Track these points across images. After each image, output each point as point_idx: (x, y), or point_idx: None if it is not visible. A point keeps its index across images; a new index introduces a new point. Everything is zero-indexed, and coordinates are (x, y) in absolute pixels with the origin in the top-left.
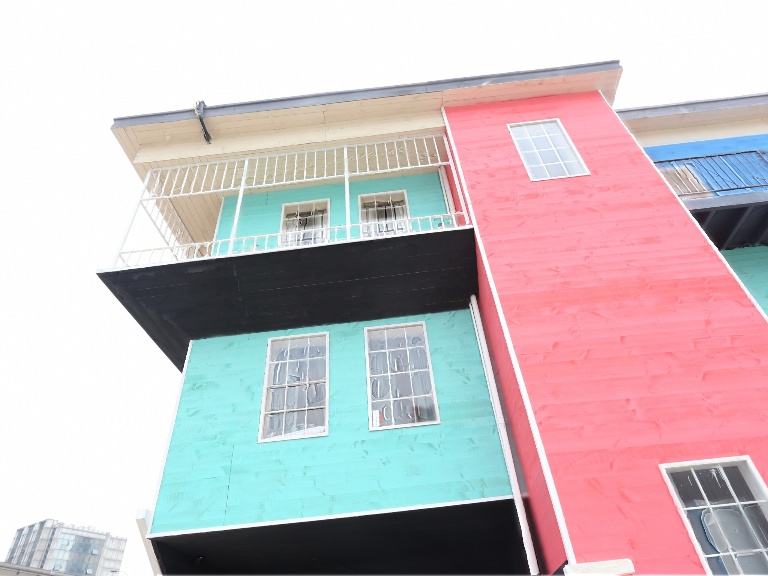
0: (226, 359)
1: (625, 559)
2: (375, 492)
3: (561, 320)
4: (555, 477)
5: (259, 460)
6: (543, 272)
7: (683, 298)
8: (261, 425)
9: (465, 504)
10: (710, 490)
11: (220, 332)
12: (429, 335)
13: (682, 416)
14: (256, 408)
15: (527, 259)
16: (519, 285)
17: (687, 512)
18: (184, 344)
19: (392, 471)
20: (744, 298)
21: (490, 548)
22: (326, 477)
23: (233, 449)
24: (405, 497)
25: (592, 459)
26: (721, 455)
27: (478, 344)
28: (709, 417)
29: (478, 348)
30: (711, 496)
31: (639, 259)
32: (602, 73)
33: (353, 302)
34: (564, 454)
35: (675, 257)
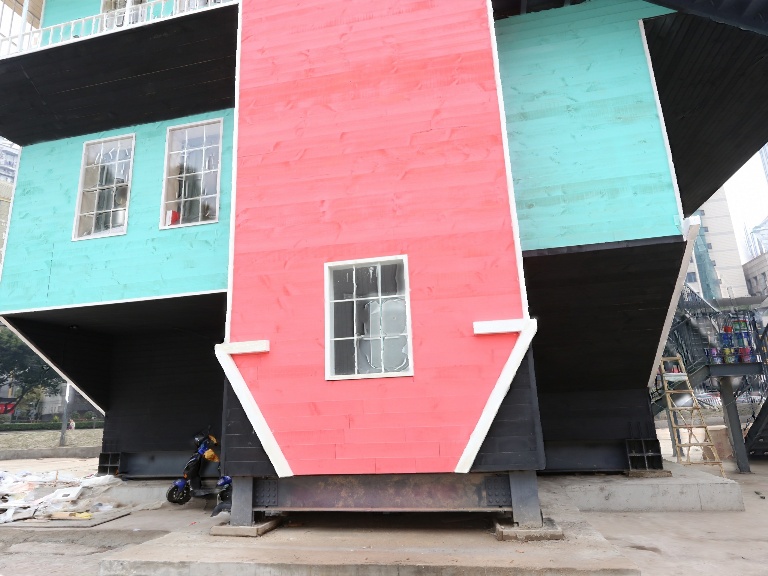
0: (49, 165)
1: (261, 340)
2: (157, 282)
3: (291, 116)
4: (236, 274)
5: (72, 256)
6: (292, 57)
7: (424, 83)
8: (74, 226)
9: None
10: (361, 285)
11: (42, 138)
12: (224, 133)
13: (365, 217)
14: (71, 210)
15: (281, 41)
16: (264, 75)
17: (333, 304)
18: None
19: (173, 264)
20: (490, 79)
21: None
22: (121, 270)
23: (53, 247)
24: (179, 286)
25: (271, 258)
26: (383, 254)
27: None
28: (389, 218)
29: None
30: (360, 291)
31: (398, 33)
32: None
33: (150, 100)
34: (249, 254)
35: (439, 27)
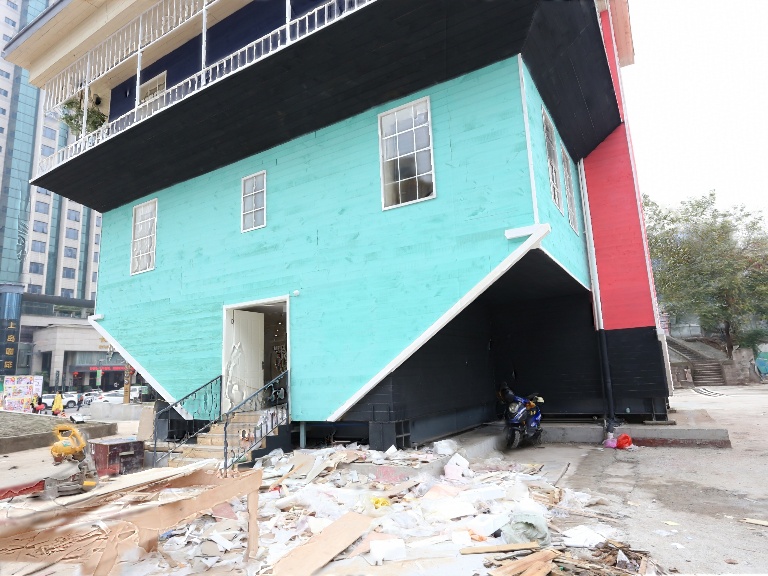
0: None
1: None
2: None
3: None
4: None
5: None
6: None
7: None
8: None
9: (584, 287)
10: None
11: (533, 67)
12: None
13: None
14: None
15: None
16: None
17: None
18: (487, 39)
19: None
20: None
21: (506, 308)
22: None
23: None
24: None
25: None
26: None
27: (582, 194)
28: None
29: (580, 196)
30: None
31: None
32: (632, 56)
33: None
34: None
35: None
